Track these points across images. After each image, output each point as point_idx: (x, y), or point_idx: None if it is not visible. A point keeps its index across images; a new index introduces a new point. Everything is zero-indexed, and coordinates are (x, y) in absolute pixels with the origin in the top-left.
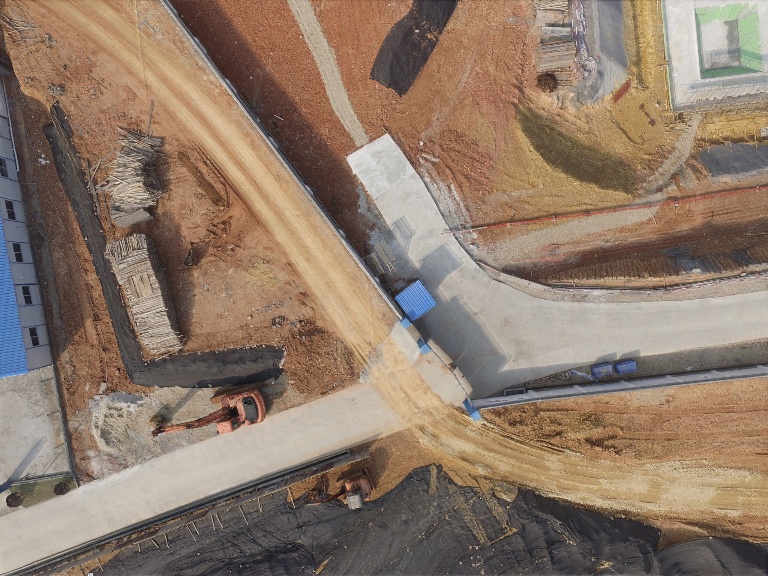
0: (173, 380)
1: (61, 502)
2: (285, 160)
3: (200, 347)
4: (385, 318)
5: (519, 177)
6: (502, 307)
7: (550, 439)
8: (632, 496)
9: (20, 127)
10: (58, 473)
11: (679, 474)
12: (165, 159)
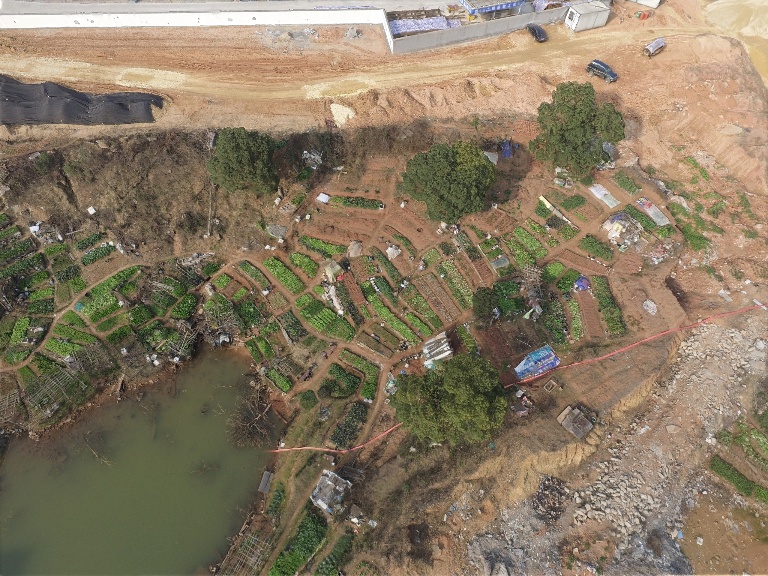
0: None
1: None
2: None
3: None
4: None
5: None
6: None
7: None
8: (14, 69)
9: None
10: None
11: (49, 62)
12: None
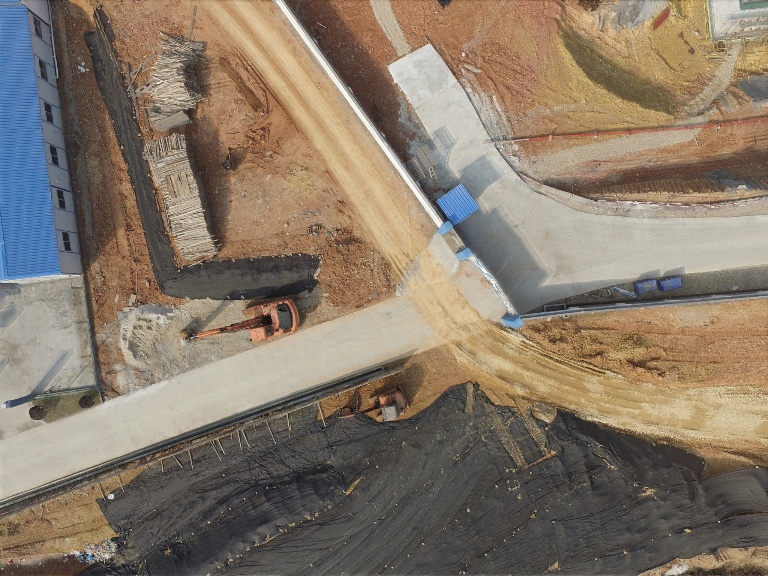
0: (205, 290)
1: (84, 418)
2: (328, 61)
3: (235, 254)
4: (424, 229)
5: (561, 91)
6: (543, 220)
7: (591, 358)
8: (675, 422)
9: (61, 35)
10: (83, 387)
11: (723, 400)
12: (206, 64)
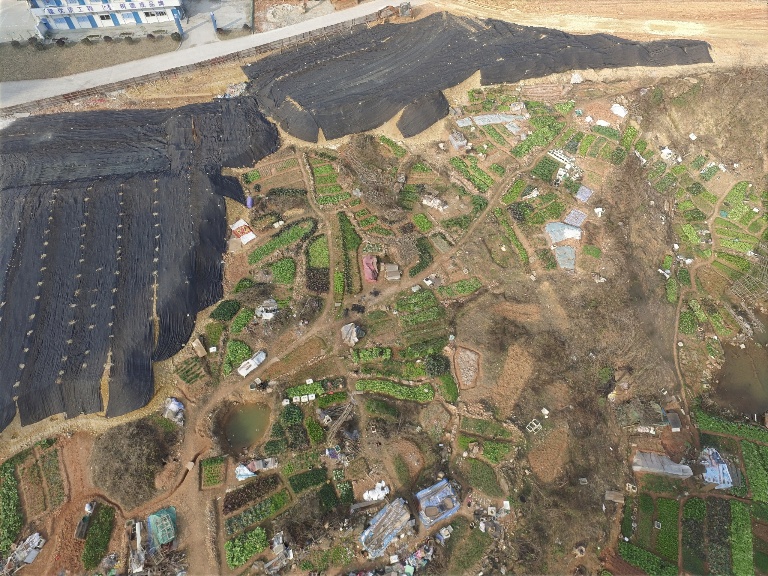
0: None
1: (241, 40)
2: None
3: None
4: None
5: None
6: None
7: (502, 4)
8: (551, 24)
9: None
10: None
11: (573, 18)
12: None
